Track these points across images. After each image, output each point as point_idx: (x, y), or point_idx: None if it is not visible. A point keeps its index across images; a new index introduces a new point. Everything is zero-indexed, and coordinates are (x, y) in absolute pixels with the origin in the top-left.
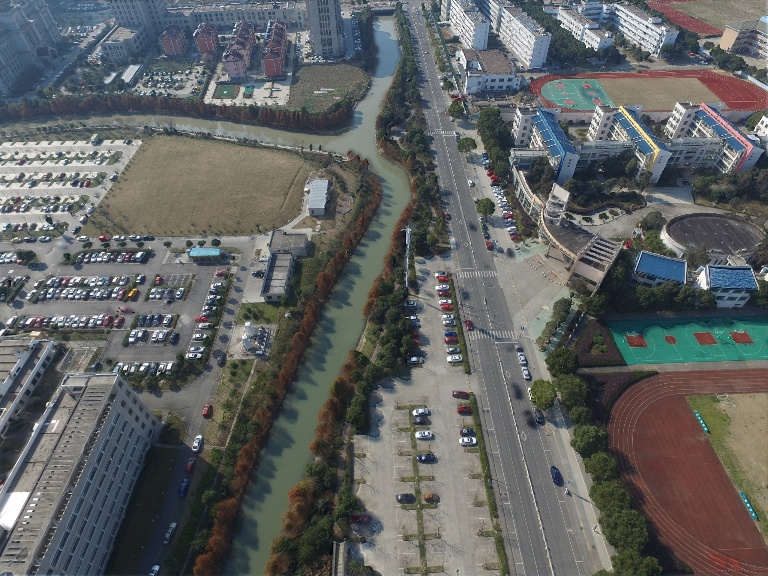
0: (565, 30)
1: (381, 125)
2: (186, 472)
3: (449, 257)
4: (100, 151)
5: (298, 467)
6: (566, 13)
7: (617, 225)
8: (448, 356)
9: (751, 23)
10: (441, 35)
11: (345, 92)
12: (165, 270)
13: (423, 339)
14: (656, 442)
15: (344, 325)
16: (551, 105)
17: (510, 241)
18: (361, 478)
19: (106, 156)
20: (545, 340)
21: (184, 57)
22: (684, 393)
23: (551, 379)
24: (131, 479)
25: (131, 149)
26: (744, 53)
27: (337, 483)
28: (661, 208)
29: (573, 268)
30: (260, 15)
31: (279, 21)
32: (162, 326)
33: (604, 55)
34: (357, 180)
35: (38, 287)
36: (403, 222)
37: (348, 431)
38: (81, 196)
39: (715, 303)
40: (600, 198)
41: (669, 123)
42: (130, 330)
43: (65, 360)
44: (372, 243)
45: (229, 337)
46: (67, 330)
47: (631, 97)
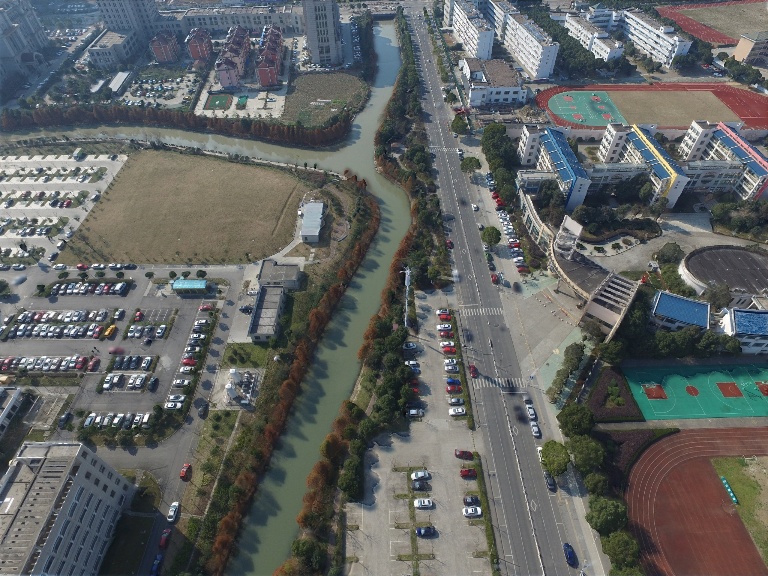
0: (573, 39)
1: (380, 141)
2: (159, 547)
3: (451, 291)
4: (83, 167)
5: (284, 542)
6: (574, 20)
7: (631, 256)
8: (450, 408)
9: (767, 33)
10: (444, 42)
11: (343, 104)
12: (146, 304)
13: (423, 387)
14: (680, 514)
15: (338, 369)
16: (559, 120)
17: (517, 273)
18: (353, 555)
19: (89, 173)
20: (556, 391)
21: (175, 64)
22: (709, 455)
23: (563, 439)
24: (97, 557)
25: (116, 165)
26: (759, 64)
27: (327, 562)
28: (678, 237)
29: (586, 308)
30: (256, 19)
31: (275, 26)
32: (140, 369)
33: (614, 66)
34: (354, 202)
35: (8, 323)
36: (402, 252)
37: (340, 498)
38: (60, 218)
39: (740, 350)
40: (613, 226)
41: (684, 142)
42: (105, 374)
43: (33, 409)
44: (369, 274)
45: (212, 383)
46: (37, 373)
47: (643, 112)
